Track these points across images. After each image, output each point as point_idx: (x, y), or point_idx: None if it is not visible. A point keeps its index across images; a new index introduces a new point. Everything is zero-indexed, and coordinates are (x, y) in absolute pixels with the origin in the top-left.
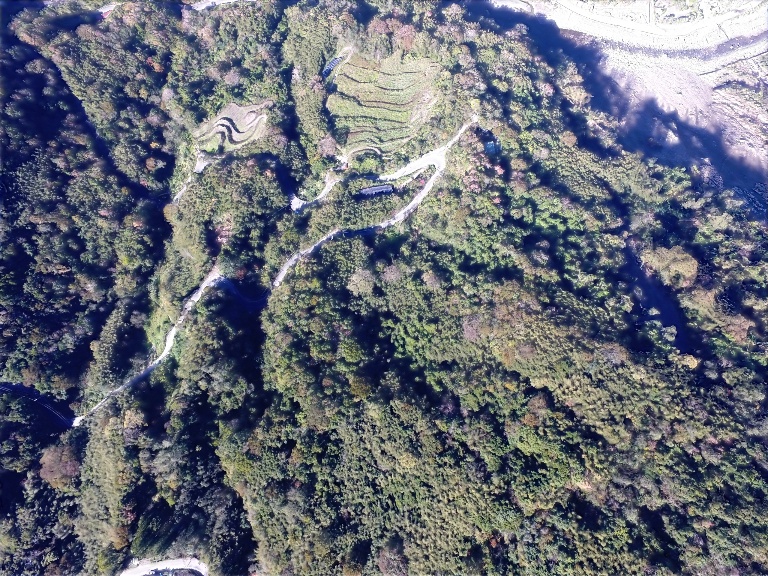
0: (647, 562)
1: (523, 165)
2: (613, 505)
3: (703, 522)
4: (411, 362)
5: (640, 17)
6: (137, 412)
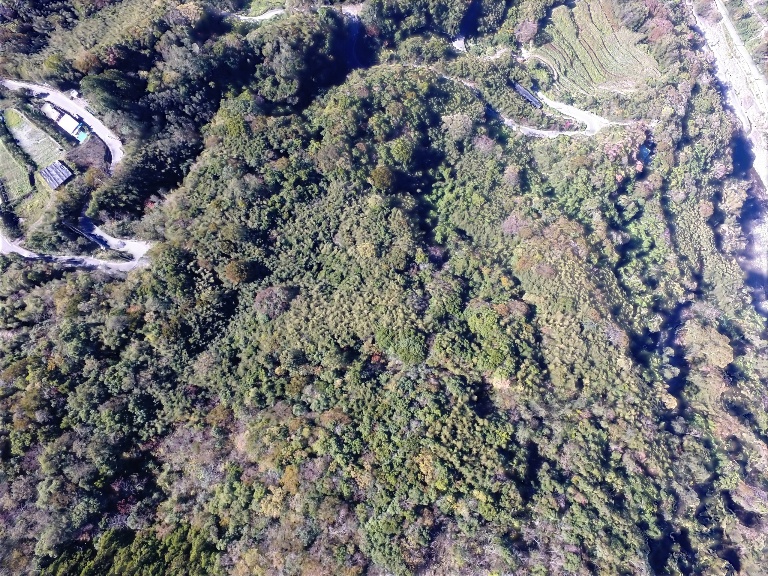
0: (502, 473)
1: (659, 183)
2: (514, 415)
3: (579, 493)
4: None
5: None
6: (198, 10)
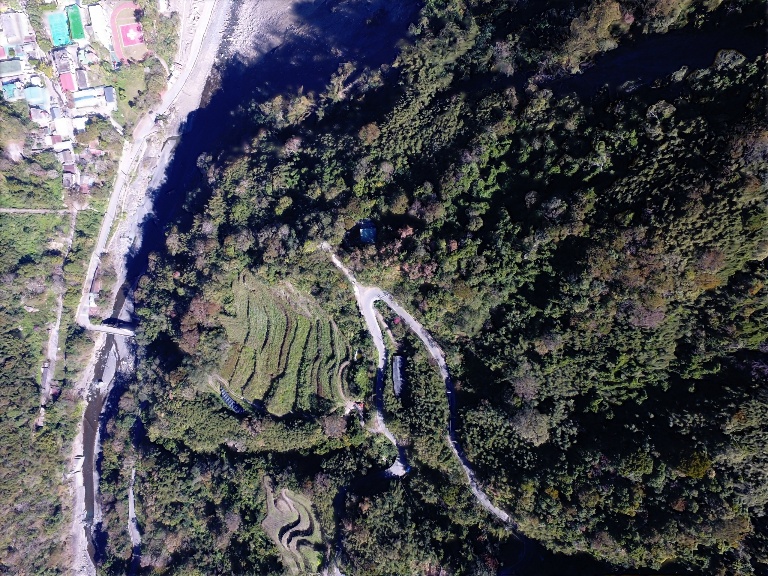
0: None
1: (403, 200)
2: None
3: None
4: (659, 389)
5: (195, 8)
6: None
